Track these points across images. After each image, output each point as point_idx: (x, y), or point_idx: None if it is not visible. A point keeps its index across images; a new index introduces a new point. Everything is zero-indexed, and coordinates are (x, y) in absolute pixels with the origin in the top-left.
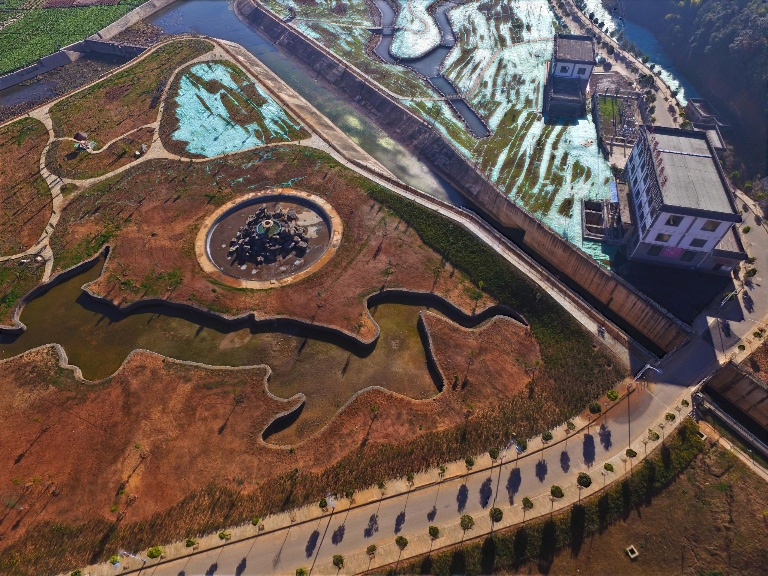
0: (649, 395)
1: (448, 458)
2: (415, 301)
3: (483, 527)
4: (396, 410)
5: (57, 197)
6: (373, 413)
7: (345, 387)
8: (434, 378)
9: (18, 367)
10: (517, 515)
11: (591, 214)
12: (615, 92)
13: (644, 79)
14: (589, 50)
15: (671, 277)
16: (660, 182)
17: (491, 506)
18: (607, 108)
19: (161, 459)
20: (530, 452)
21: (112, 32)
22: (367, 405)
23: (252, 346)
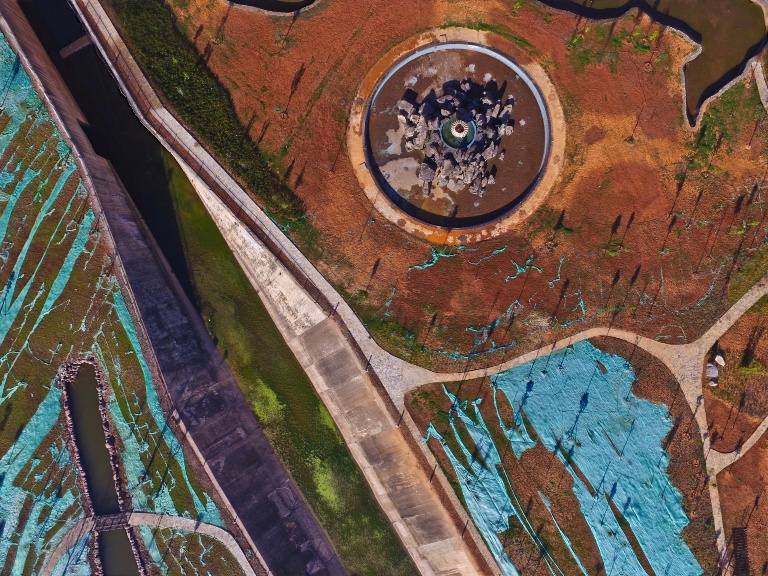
0: None
1: None
2: (256, 3)
3: None
4: None
5: None
6: None
7: None
8: None
9: None
10: None
11: None
12: None
13: None
14: None
15: None
16: None
17: None
18: None
19: None
20: None
21: None
22: None
23: None
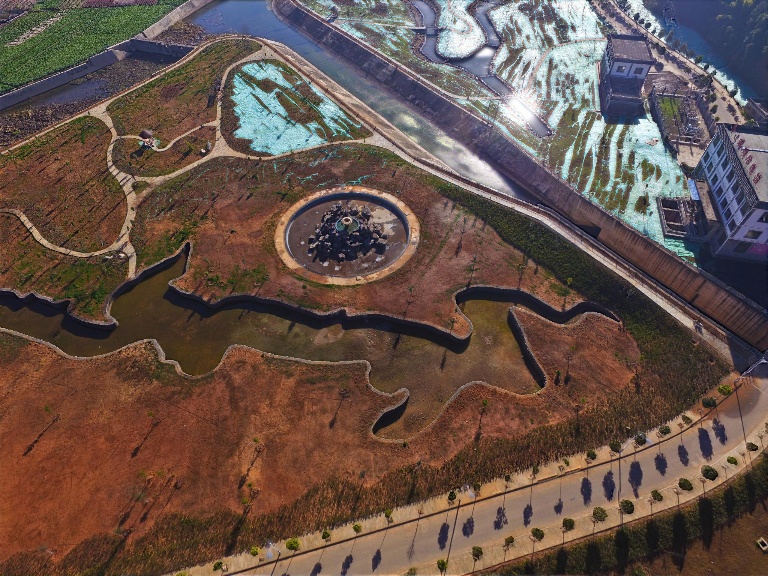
0: (756, 390)
1: (566, 452)
2: (502, 297)
3: (612, 519)
4: (503, 405)
5: (130, 194)
6: (481, 408)
7: (446, 382)
8: (533, 373)
9: (119, 362)
10: (644, 508)
11: (668, 212)
12: (673, 91)
13: (702, 79)
14: (644, 50)
15: (759, 274)
16: (751, 179)
17: (616, 499)
18: (666, 107)
19: (277, 453)
20: (647, 446)
21: (155, 32)
22: (473, 400)
23: (346, 342)
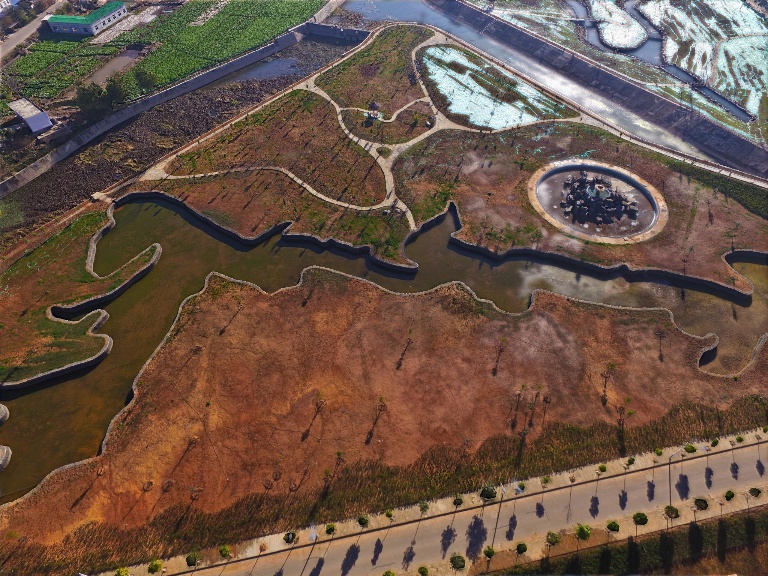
0: None
1: None
2: (766, 262)
3: None
4: None
5: (379, 158)
6: None
7: (745, 330)
8: None
9: (440, 299)
10: None
11: None
12: None
13: None
14: None
15: None
16: None
17: None
18: None
19: (623, 379)
20: None
21: (322, 17)
22: None
23: (636, 292)
